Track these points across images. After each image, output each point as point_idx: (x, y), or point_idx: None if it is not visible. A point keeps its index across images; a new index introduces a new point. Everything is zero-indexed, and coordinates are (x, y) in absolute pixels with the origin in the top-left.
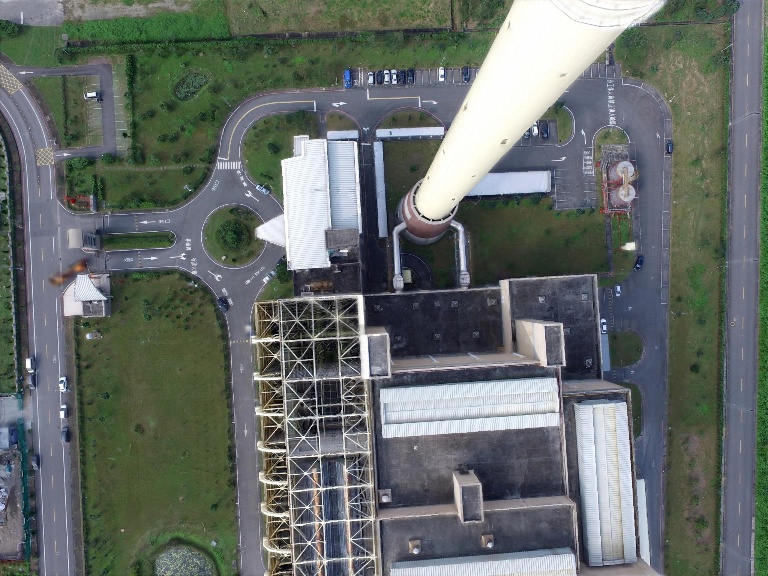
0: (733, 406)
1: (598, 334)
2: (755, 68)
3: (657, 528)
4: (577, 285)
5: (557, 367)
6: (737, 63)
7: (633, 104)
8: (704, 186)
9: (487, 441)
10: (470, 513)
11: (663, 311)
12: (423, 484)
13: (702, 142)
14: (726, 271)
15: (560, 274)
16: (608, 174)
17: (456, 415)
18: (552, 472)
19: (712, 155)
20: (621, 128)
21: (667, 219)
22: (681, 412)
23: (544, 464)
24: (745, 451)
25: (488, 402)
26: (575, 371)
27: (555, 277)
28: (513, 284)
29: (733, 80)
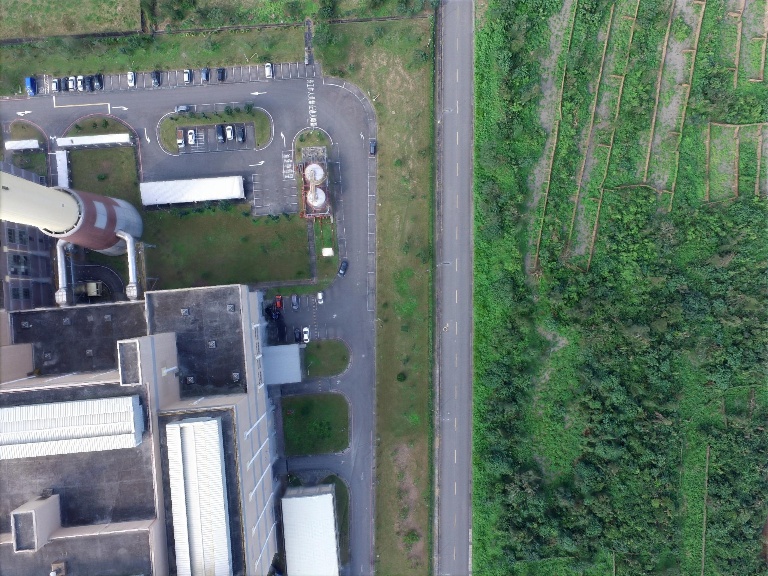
0: (447, 414)
1: (243, 346)
2: (465, 63)
3: (367, 543)
4: (223, 296)
5: (132, 386)
6: (446, 58)
7: (335, 104)
8: (411, 187)
9: (75, 464)
10: (25, 542)
11: (370, 318)
12: (6, 510)
13: (407, 142)
14: (437, 275)
15: (261, 282)
16: (304, 178)
17: (26, 438)
18: (146, 495)
19: (418, 155)
20: (323, 129)
21: (373, 222)
22: (390, 422)
23: (137, 486)
24: (460, 461)
25: (60, 424)
26: (222, 385)
27: (196, 288)
28: (154, 297)
29: (442, 76)
